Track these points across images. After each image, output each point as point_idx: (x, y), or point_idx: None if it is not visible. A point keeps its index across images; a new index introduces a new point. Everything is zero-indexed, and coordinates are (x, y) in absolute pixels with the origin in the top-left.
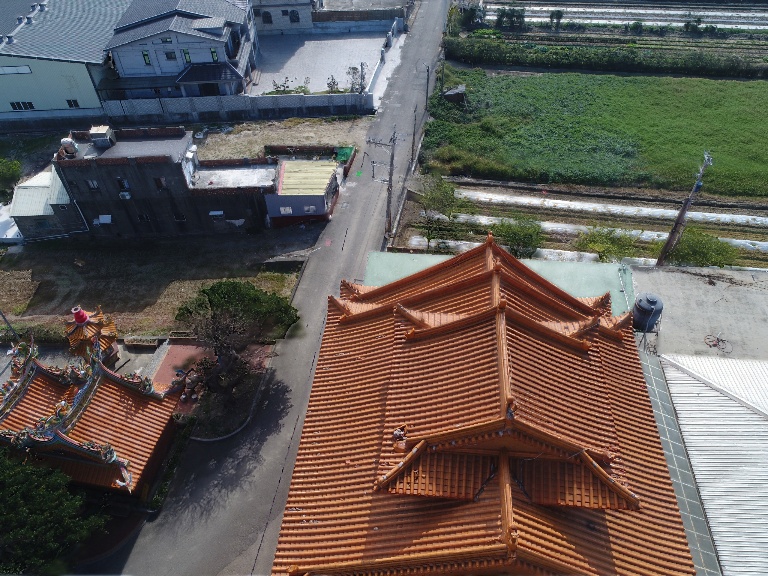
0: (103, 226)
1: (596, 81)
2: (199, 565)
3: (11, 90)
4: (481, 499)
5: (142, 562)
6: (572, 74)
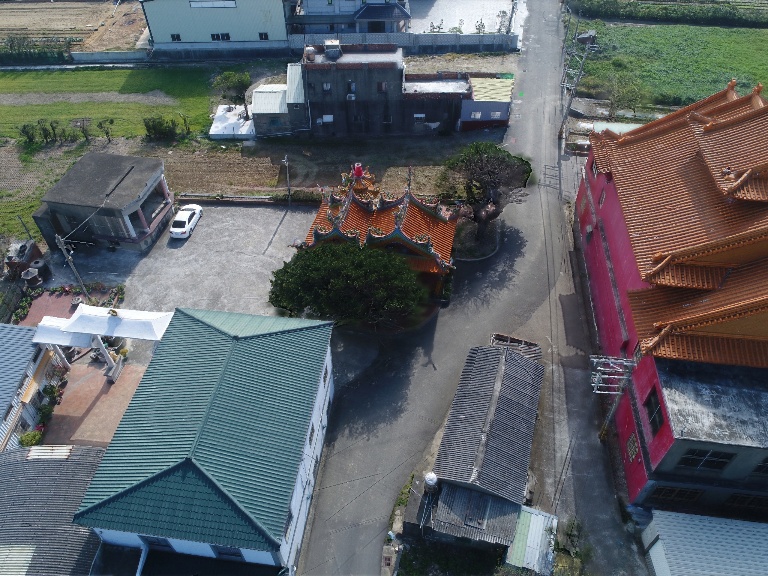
0: (323, 125)
1: (704, 31)
2: (493, 331)
3: (215, 22)
4: None
5: (447, 330)
6: (682, 26)
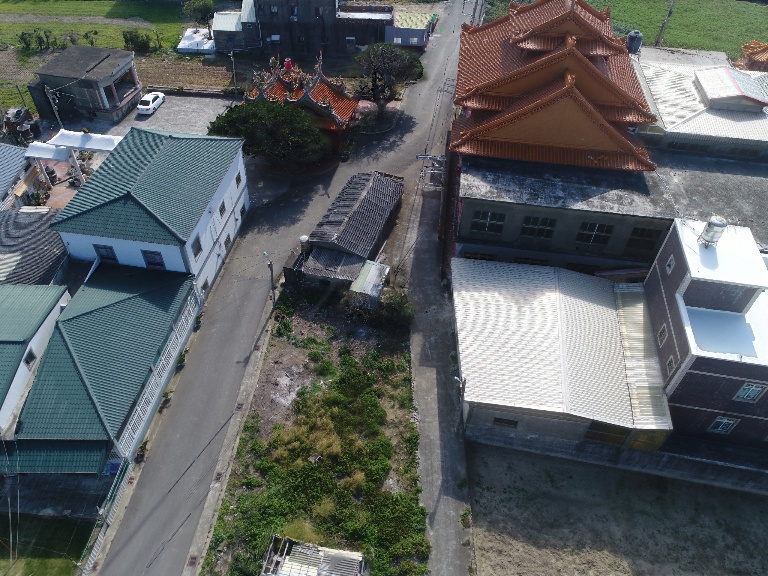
0: (272, 44)
1: None
2: None
3: None
4: (557, 49)
5: (343, 175)
6: None
